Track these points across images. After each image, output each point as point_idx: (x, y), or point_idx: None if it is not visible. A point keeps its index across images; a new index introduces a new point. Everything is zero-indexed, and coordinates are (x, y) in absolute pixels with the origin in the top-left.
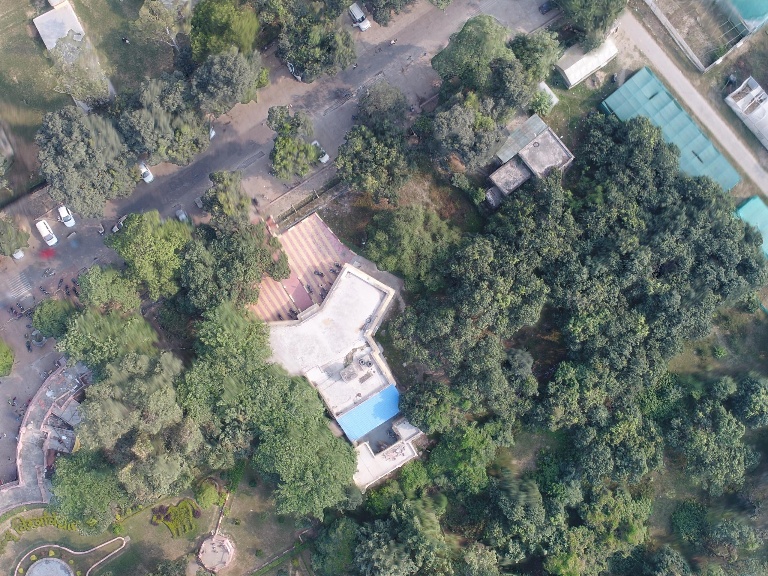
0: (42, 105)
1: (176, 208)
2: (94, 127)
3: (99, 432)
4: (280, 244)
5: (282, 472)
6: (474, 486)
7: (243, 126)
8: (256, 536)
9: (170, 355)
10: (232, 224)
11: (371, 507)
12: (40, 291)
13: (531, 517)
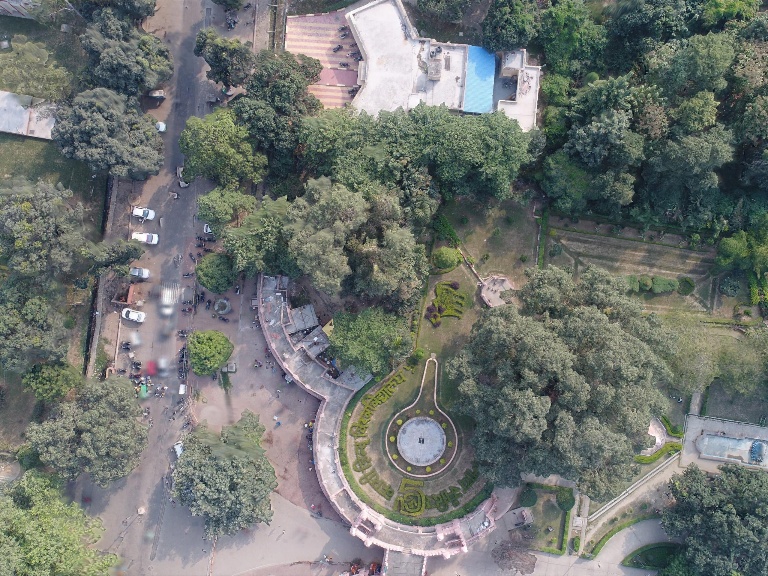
0: (43, 170)
1: (201, 108)
2: (89, 98)
3: (330, 261)
4: (291, 54)
5: (472, 158)
6: (600, 41)
7: (177, 24)
8: (508, 252)
9: (312, 180)
10: (246, 67)
11: (554, 138)
12: (187, 279)
13: (659, 2)
